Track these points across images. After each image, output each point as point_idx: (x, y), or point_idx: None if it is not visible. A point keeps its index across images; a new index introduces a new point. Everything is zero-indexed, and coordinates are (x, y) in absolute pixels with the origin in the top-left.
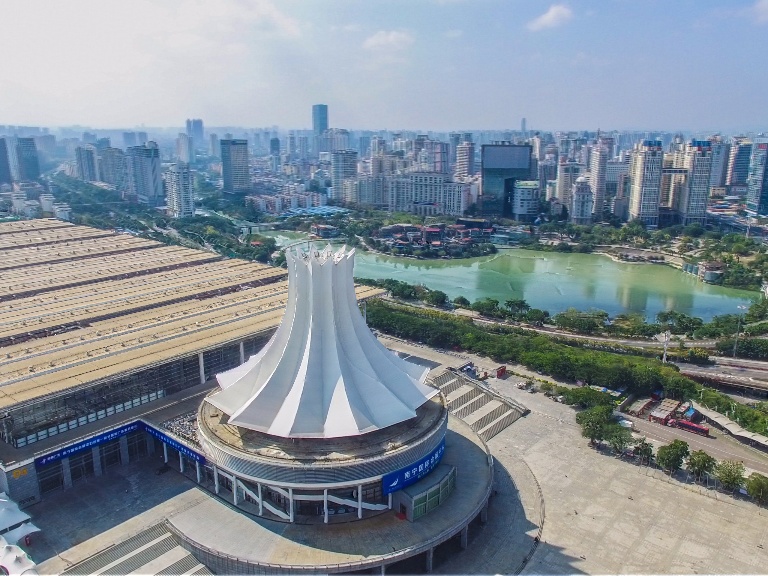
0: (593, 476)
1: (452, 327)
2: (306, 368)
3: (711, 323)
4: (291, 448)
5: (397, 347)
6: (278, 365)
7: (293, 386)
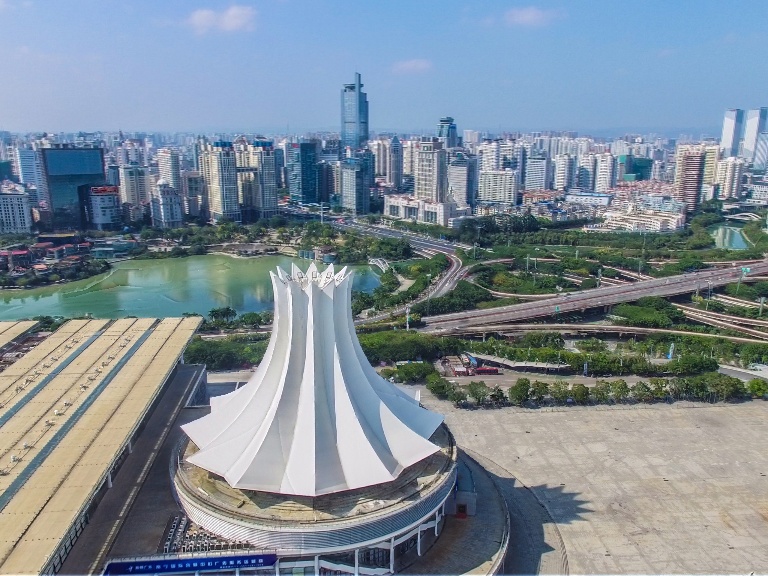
0: (489, 428)
1: (216, 347)
2: (351, 404)
3: (377, 295)
4: (381, 493)
5: (210, 379)
6: (315, 412)
7: (338, 430)
